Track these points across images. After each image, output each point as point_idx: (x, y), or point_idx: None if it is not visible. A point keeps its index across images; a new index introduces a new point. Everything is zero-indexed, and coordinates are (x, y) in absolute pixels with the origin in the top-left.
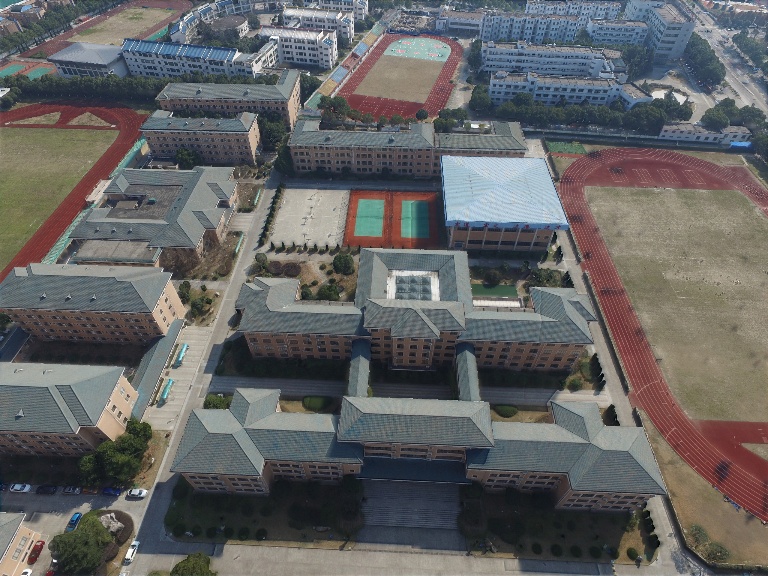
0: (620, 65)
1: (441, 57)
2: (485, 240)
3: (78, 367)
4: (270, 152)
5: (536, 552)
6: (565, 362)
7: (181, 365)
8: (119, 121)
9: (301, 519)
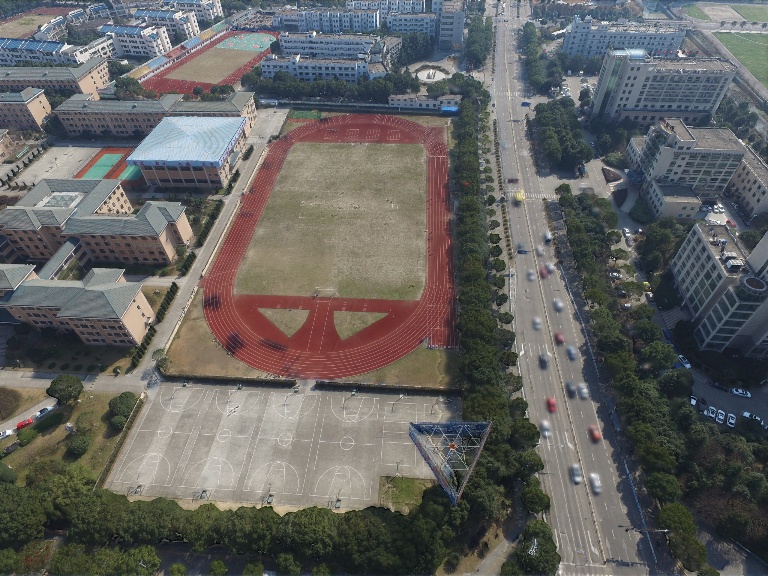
0: (377, 47)
1: (261, 48)
2: (171, 178)
3: None
4: None
5: (49, 368)
6: (159, 255)
7: None
8: None
9: None
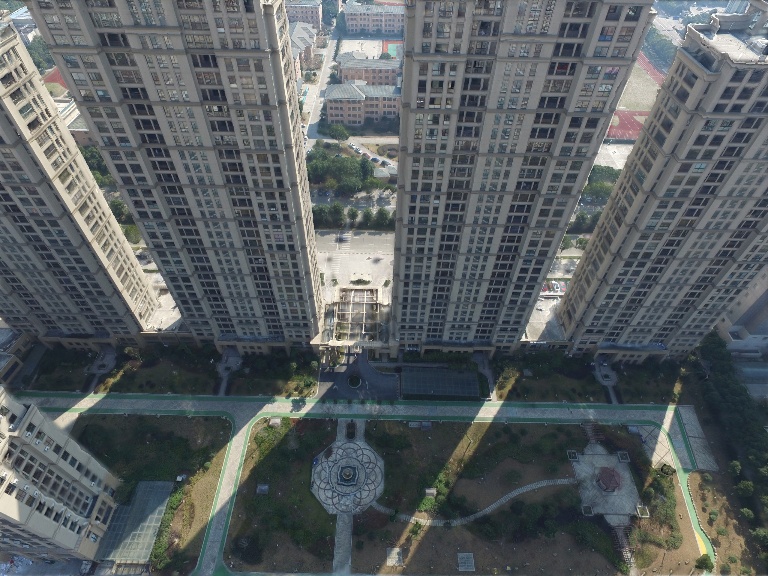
0: None
1: None
2: None
3: None
4: (328, 25)
5: None
6: None
7: (307, 95)
8: None
9: (380, 130)
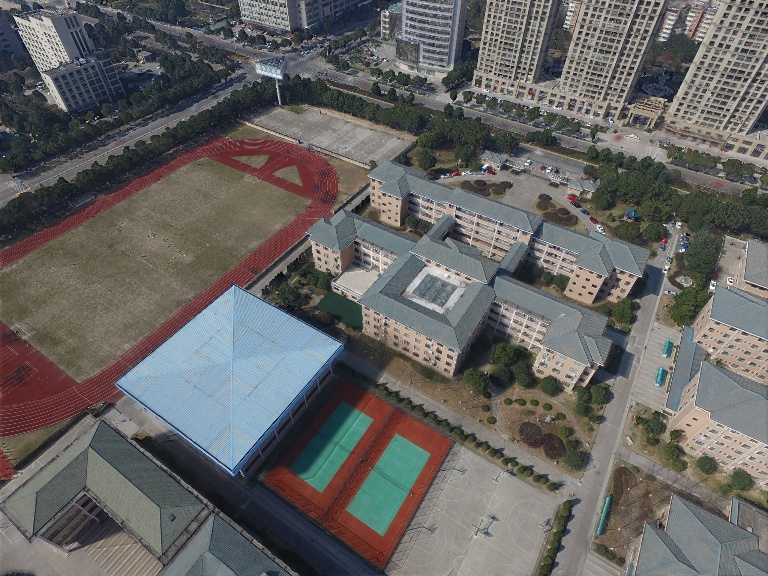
0: None
1: None
2: None
3: (756, 330)
4: None
5: None
6: None
7: None
8: None
9: None
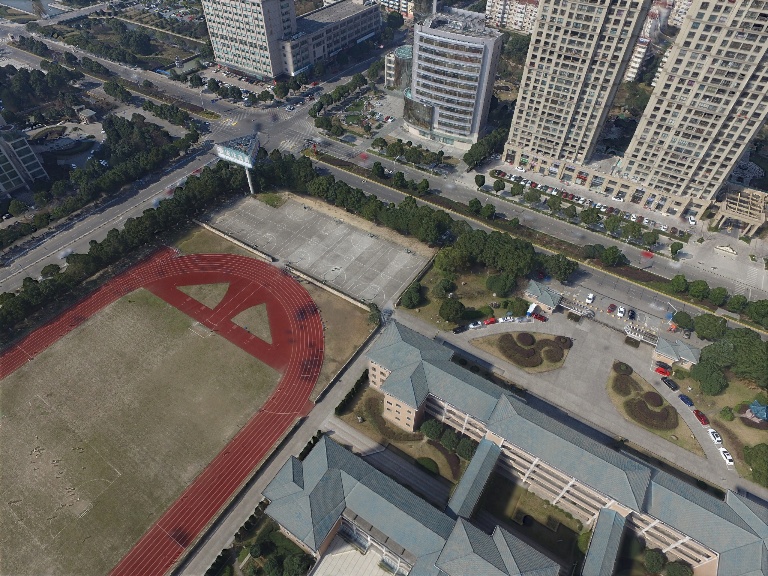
0: None
1: None
2: None
3: None
4: None
5: (478, 368)
6: None
7: None
8: None
9: None
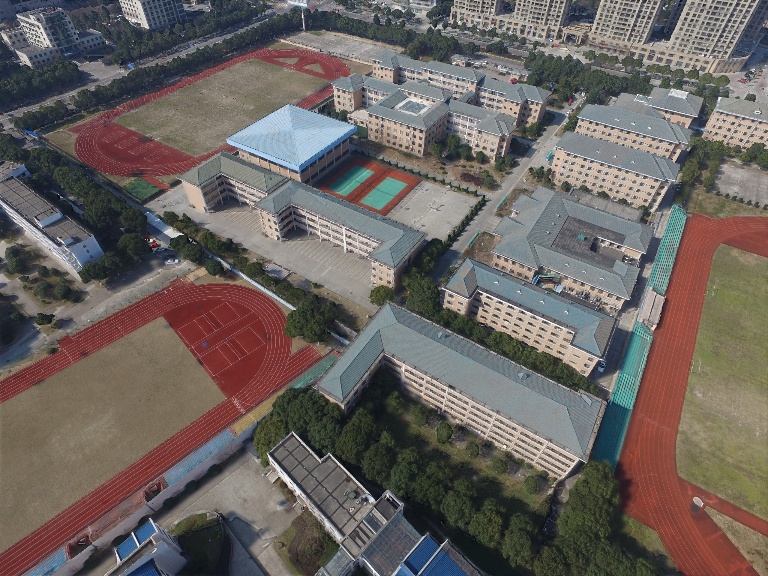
0: None
1: None
2: None
3: (602, 120)
4: None
5: None
6: None
7: None
8: (693, 518)
9: None
